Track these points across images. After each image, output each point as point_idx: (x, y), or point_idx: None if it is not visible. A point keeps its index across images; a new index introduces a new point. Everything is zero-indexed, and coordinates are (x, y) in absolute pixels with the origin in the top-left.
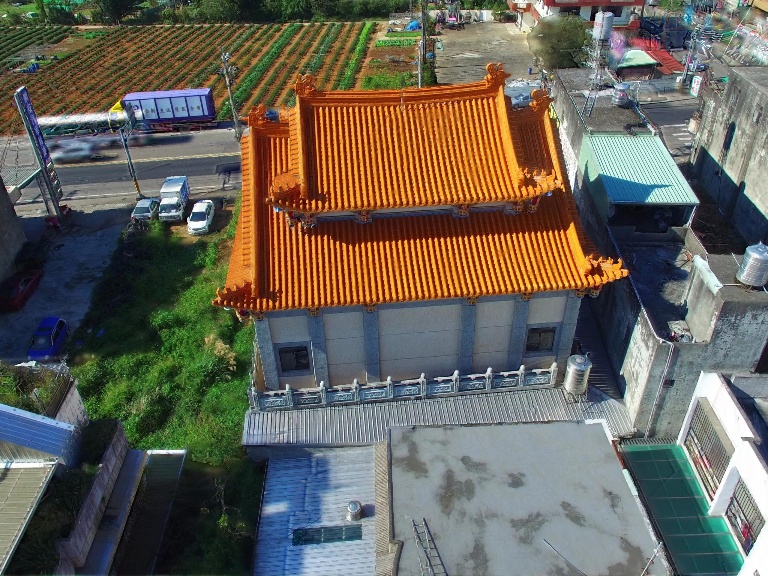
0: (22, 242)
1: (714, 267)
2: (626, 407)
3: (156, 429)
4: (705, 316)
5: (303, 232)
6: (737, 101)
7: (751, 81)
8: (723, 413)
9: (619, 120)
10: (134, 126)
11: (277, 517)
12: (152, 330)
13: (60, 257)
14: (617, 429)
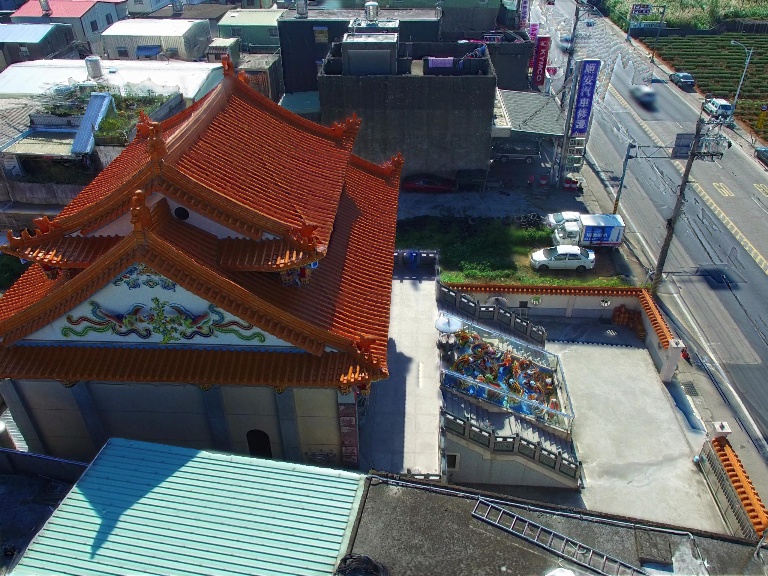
0: (481, 167)
1: None
2: None
3: None
4: None
5: None
6: None
7: None
8: None
9: (433, 573)
10: (679, 157)
11: None
12: None
13: (486, 196)
14: None
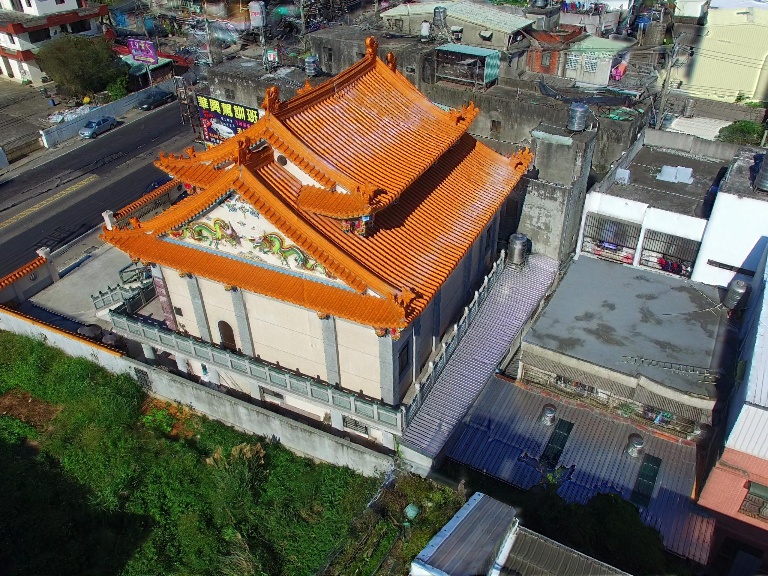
0: None
1: (549, 132)
2: (540, 254)
3: (280, 568)
4: (565, 163)
5: (365, 237)
6: (332, 57)
7: (337, 39)
8: (611, 210)
9: None
10: None
11: (518, 471)
12: (113, 518)
13: None
14: (553, 267)
